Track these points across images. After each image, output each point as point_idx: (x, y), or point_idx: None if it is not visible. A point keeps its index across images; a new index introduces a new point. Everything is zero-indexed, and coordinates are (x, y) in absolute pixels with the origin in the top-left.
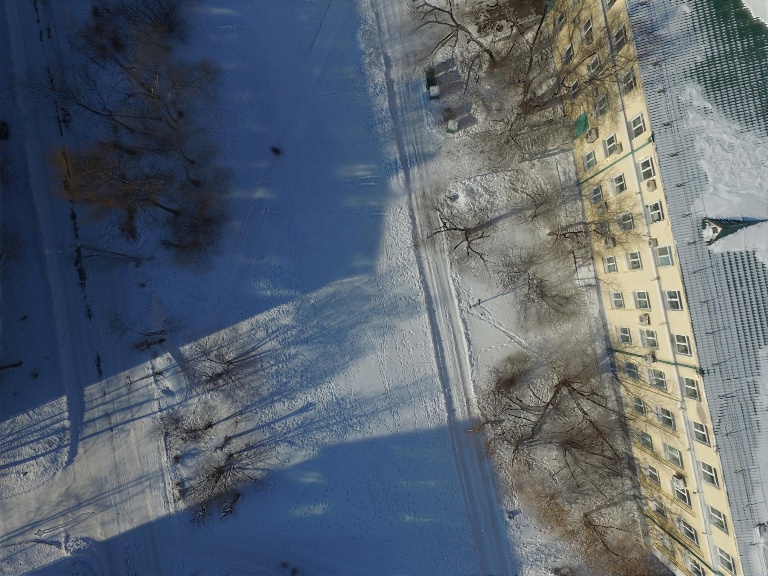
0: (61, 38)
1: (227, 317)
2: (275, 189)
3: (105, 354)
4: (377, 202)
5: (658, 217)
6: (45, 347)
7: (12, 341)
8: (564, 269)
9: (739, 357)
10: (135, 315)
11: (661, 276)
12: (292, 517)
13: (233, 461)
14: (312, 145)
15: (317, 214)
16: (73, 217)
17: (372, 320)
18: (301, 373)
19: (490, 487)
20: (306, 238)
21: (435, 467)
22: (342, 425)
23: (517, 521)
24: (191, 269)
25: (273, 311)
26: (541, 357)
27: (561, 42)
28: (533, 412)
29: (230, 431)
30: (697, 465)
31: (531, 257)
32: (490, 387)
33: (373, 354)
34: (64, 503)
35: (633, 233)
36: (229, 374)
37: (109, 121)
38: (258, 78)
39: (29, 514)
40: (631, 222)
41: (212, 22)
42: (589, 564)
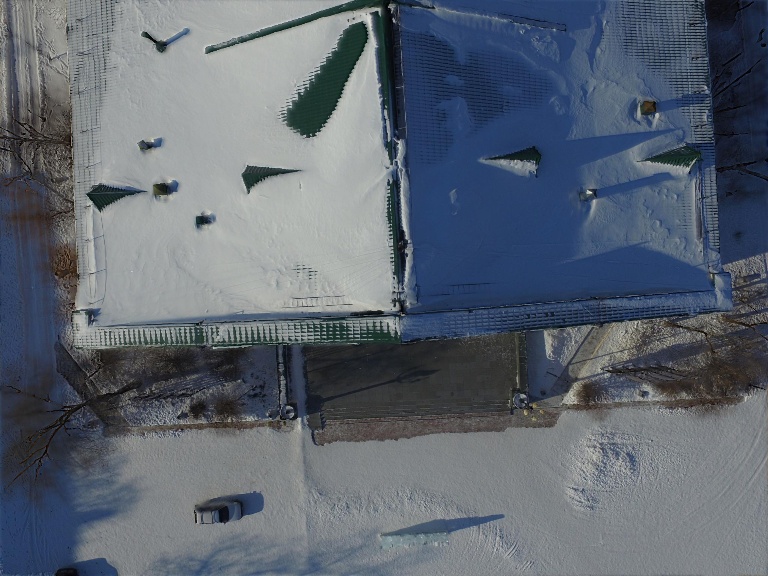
0: None
1: None
2: None
3: None
4: None
5: None
6: None
7: None
8: None
9: (99, 12)
10: None
11: None
12: None
13: None
14: None
15: None
16: None
17: None
18: None
19: (45, 244)
20: None
21: None
22: None
23: (66, 280)
24: None
25: None
26: None
27: None
28: None
29: None
30: None
31: None
32: None
33: None
34: None
35: None
36: None
37: None
38: None
39: None
40: None
41: None
42: None
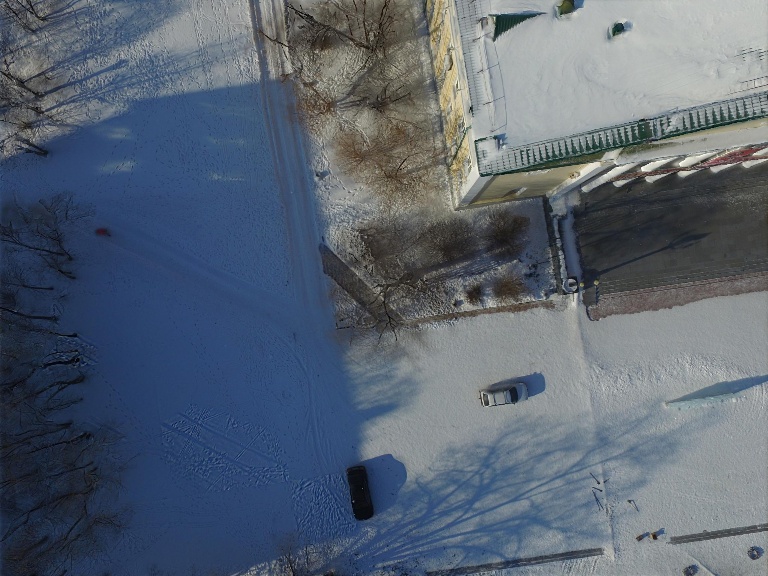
0: None
1: None
2: None
3: None
4: None
5: None
6: None
7: None
8: None
9: None
10: None
11: None
12: (100, 176)
13: (43, 117)
14: None
15: None
16: None
17: None
18: (115, 30)
19: (301, 148)
20: None
21: (246, 126)
22: (154, 82)
23: (326, 182)
24: None
25: None
26: (358, 20)
27: None
28: None
29: (41, 88)
30: (454, 21)
31: None
32: (305, 48)
33: (188, 12)
34: None
35: None
36: (43, 30)
37: None
38: None
39: None
40: None
41: None
42: (397, 227)
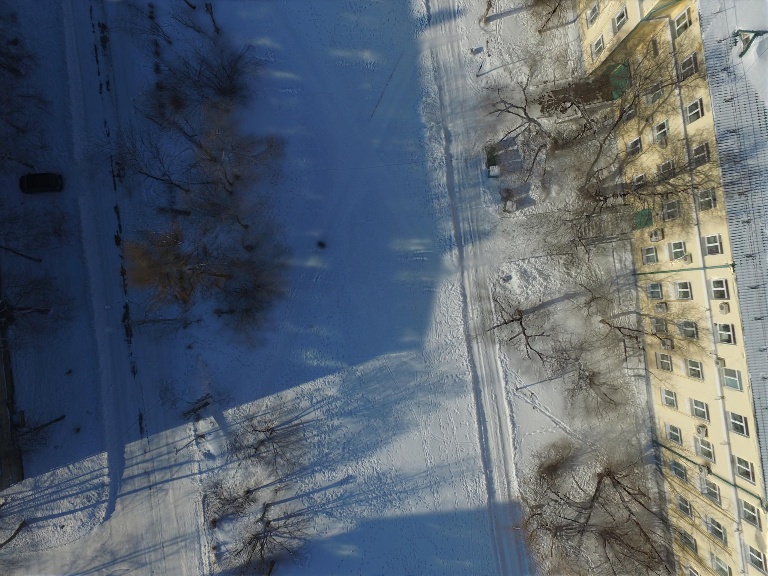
0: (120, 92)
1: (272, 384)
2: (327, 258)
3: (147, 412)
4: (429, 278)
5: (727, 338)
6: (88, 402)
7: (56, 394)
8: (614, 357)
9: None
10: (179, 375)
11: (726, 396)
12: None
13: (270, 528)
14: (367, 216)
15: (368, 286)
16: (122, 273)
17: (417, 396)
18: (343, 445)
19: (526, 571)
20: (356, 310)
21: (472, 548)
22: (381, 500)
23: None
24: (239, 335)
25: (319, 381)
26: (585, 444)
27: (628, 133)
28: (580, 510)
29: (269, 498)
30: None
31: (581, 343)
32: (532, 471)
33: (417, 431)
34: (99, 558)
35: (696, 344)
36: (271, 441)
37: (167, 185)
38: (316, 145)
39: (64, 567)
40: (694, 331)
41: (273, 85)
42: None
